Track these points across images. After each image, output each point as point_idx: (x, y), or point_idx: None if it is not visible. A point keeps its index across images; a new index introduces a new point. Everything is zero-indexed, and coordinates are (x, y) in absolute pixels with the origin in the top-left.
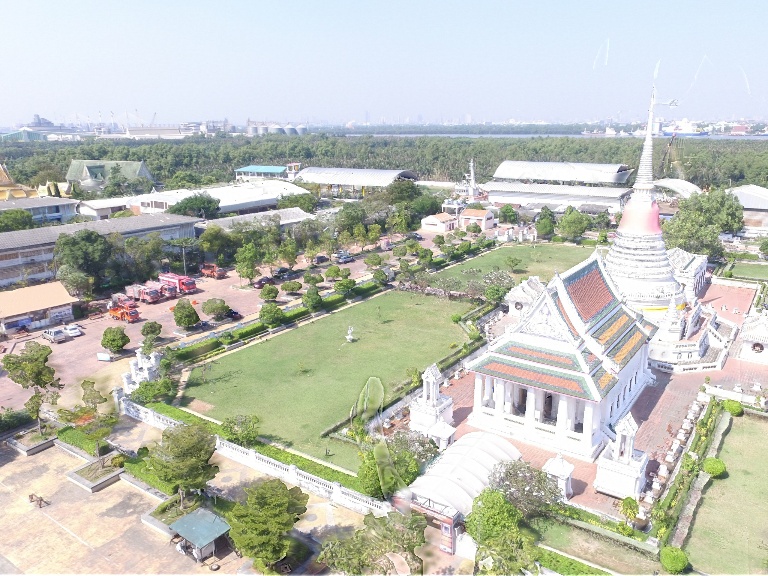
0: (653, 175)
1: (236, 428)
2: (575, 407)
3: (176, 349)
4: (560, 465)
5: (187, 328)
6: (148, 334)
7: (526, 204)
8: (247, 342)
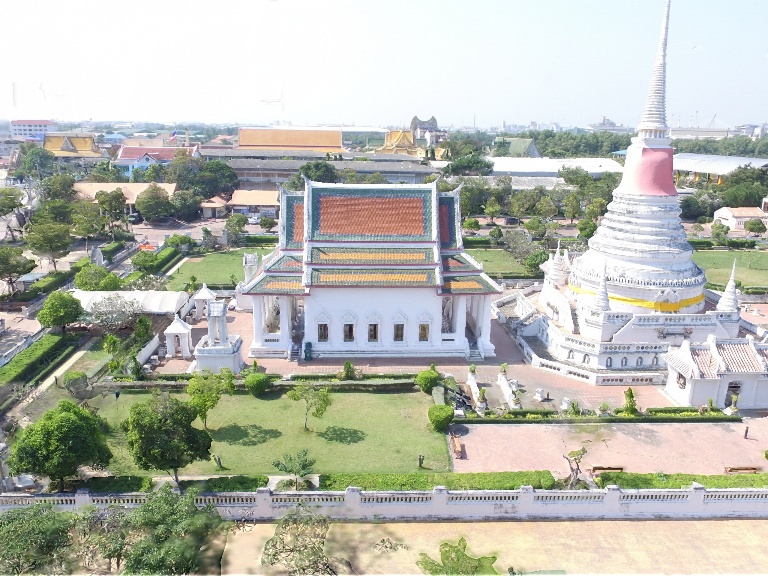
0: None
1: None
2: None
3: (256, 235)
4: None
5: None
6: (262, 225)
7: None
8: None
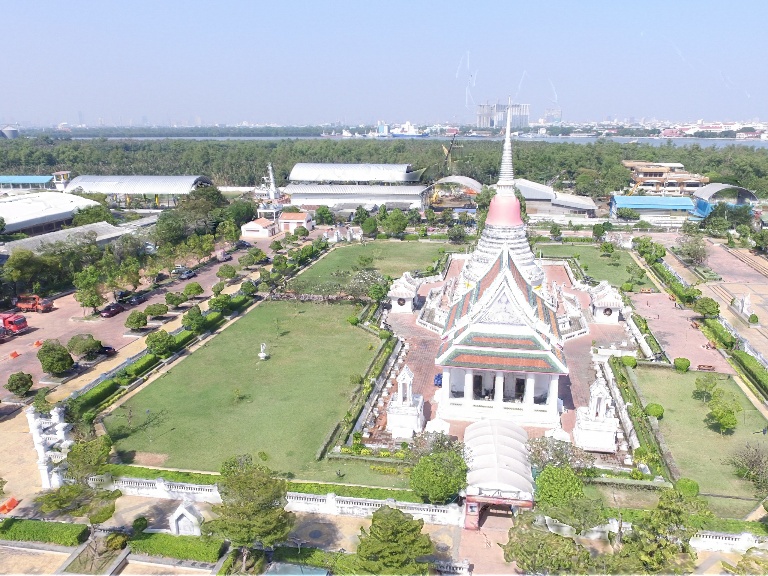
0: (441, 173)
1: (238, 471)
2: None
3: None
4: (562, 434)
5: (57, 374)
6: (18, 389)
7: (333, 205)
8: (146, 378)
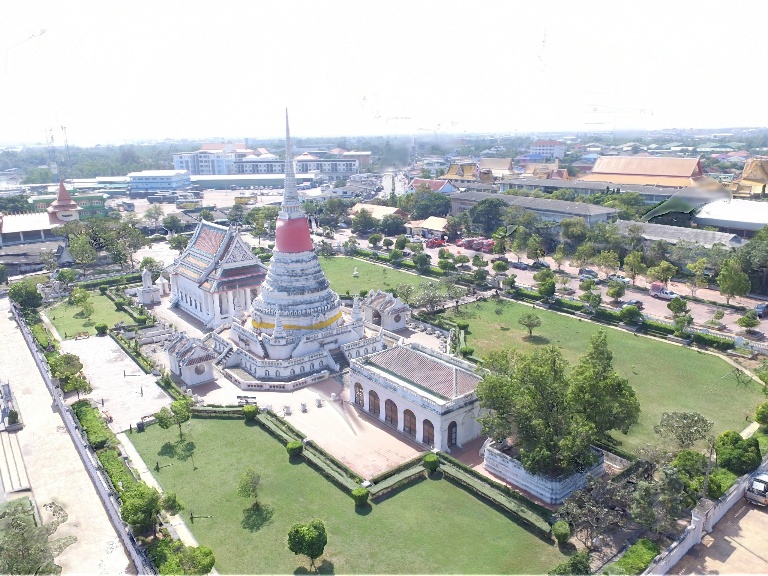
0: None
1: None
2: None
3: None
4: None
5: None
6: None
7: None
8: (375, 261)
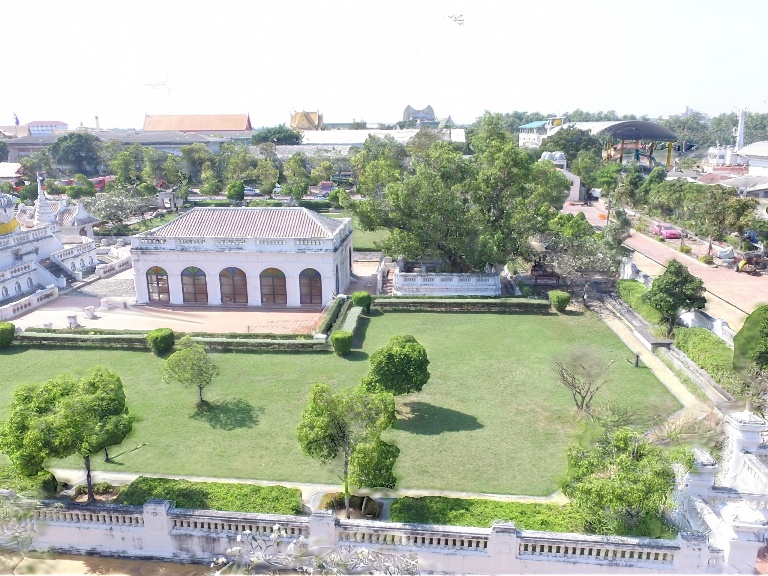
0: None
1: None
2: None
3: None
4: None
5: None
6: None
7: None
8: None
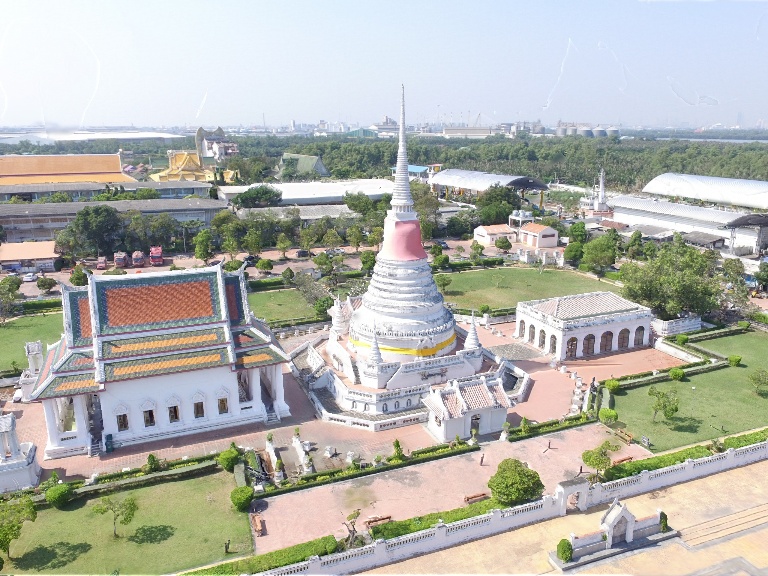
0: None
1: None
2: (86, 408)
3: (34, 300)
4: None
5: None
6: (39, 287)
7: None
8: None
